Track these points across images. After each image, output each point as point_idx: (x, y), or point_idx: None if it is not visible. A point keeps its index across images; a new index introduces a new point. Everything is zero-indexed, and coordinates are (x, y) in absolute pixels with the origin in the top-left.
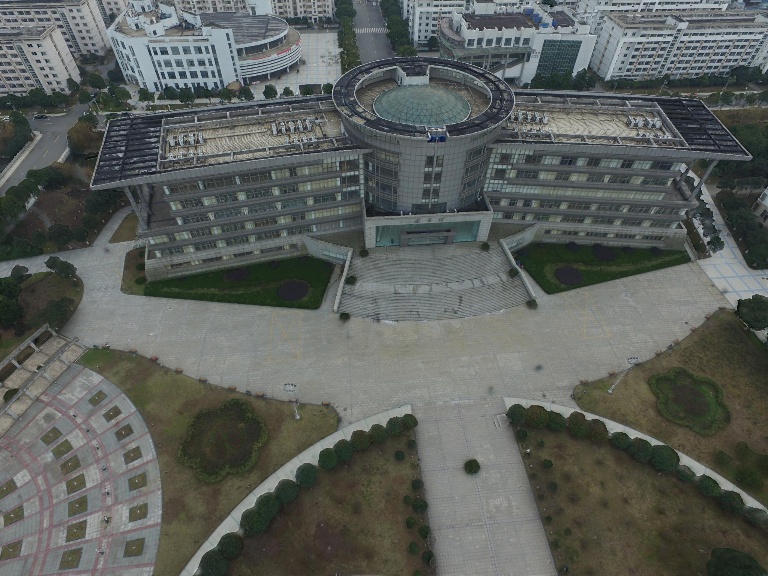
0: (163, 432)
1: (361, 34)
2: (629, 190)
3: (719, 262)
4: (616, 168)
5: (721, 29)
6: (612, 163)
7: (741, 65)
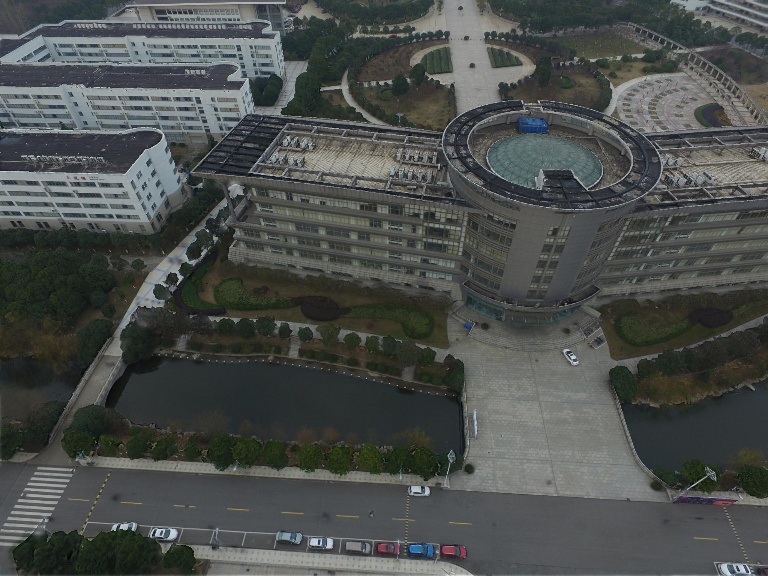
0: None
1: None
2: None
3: None
4: None
5: None
6: None
7: None
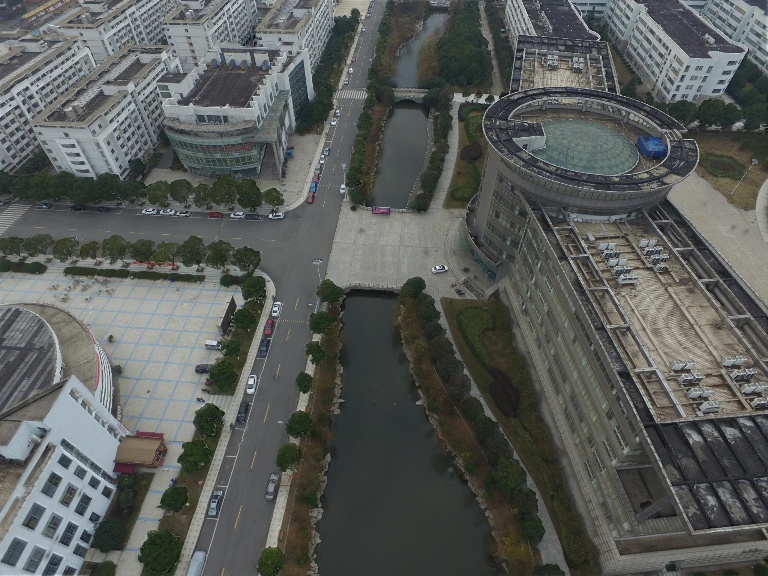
0: None
1: None
2: None
3: None
4: None
5: (319, 2)
6: None
7: (328, 24)
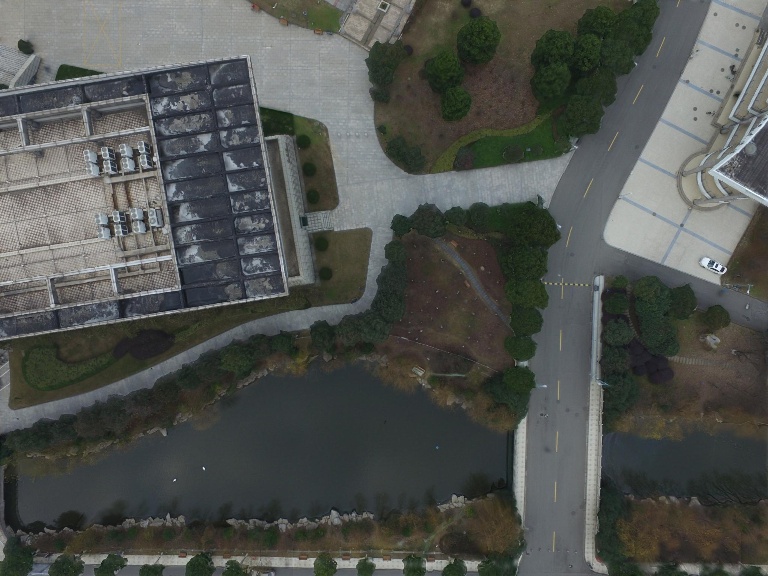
0: None
1: None
2: None
3: None
4: None
5: None
6: None
7: None
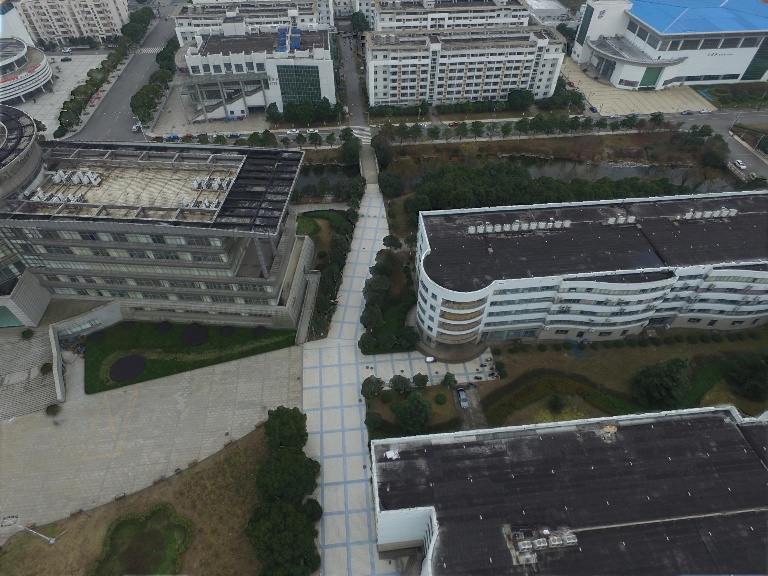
0: None
1: (145, 55)
2: (186, 266)
3: (330, 345)
4: (148, 244)
5: (483, 50)
6: (140, 238)
7: (523, 88)
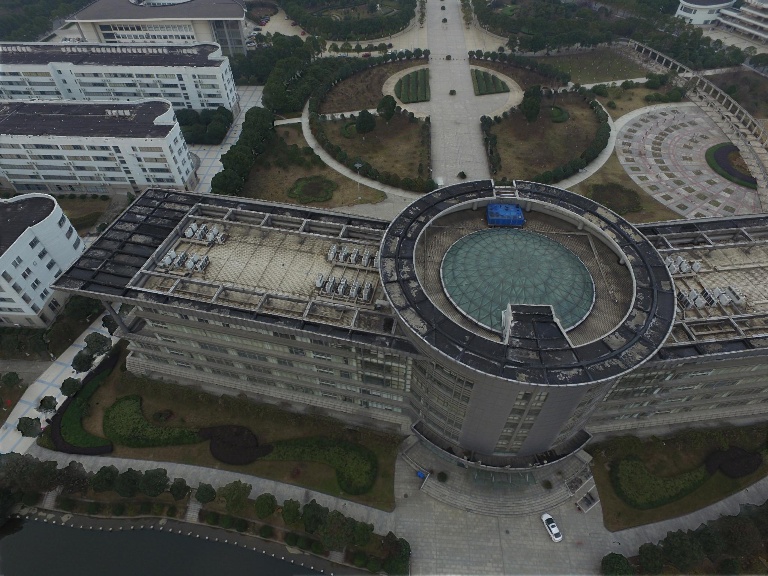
0: (656, 205)
1: None
2: None
3: None
4: None
5: None
6: None
7: None
